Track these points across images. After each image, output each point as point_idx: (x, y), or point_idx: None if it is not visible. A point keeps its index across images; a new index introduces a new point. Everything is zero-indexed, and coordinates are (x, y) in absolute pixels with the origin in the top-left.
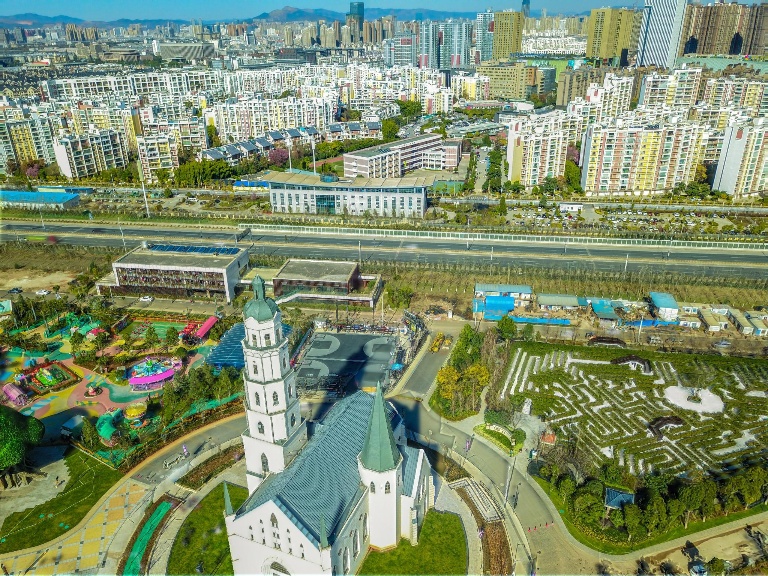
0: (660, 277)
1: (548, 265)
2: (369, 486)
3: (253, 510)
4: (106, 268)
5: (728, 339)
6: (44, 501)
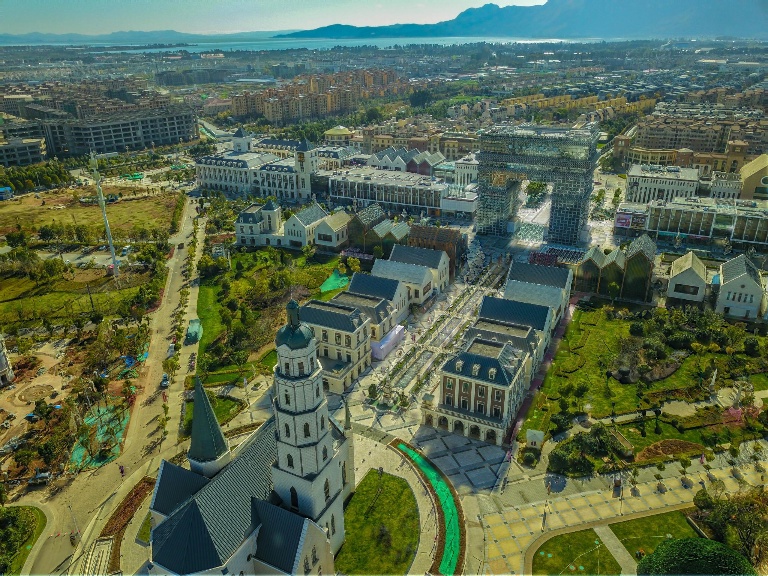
0: None
1: None
2: None
3: None
4: None
5: None
6: None
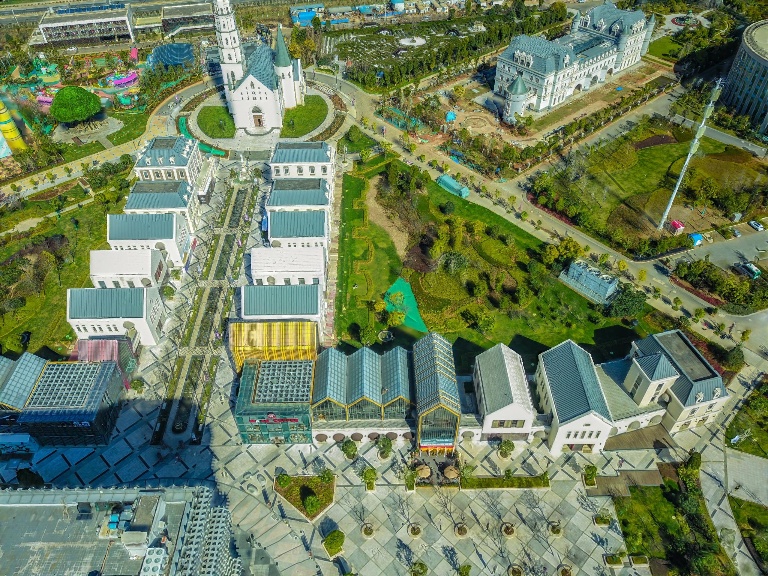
0: None
1: None
2: (282, 76)
3: (242, 83)
4: (22, 35)
5: None
6: (119, 129)
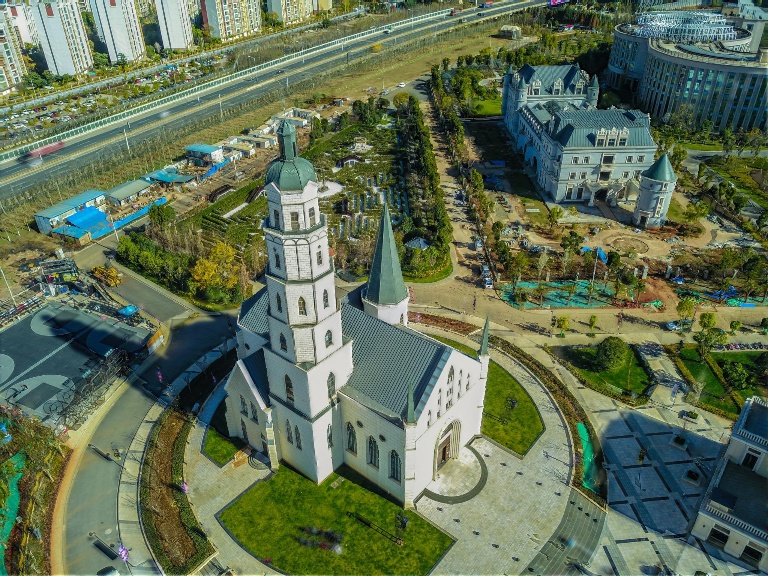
0: (177, 133)
1: (79, 164)
2: (399, 322)
3: (437, 384)
4: None
5: (267, 155)
6: None
